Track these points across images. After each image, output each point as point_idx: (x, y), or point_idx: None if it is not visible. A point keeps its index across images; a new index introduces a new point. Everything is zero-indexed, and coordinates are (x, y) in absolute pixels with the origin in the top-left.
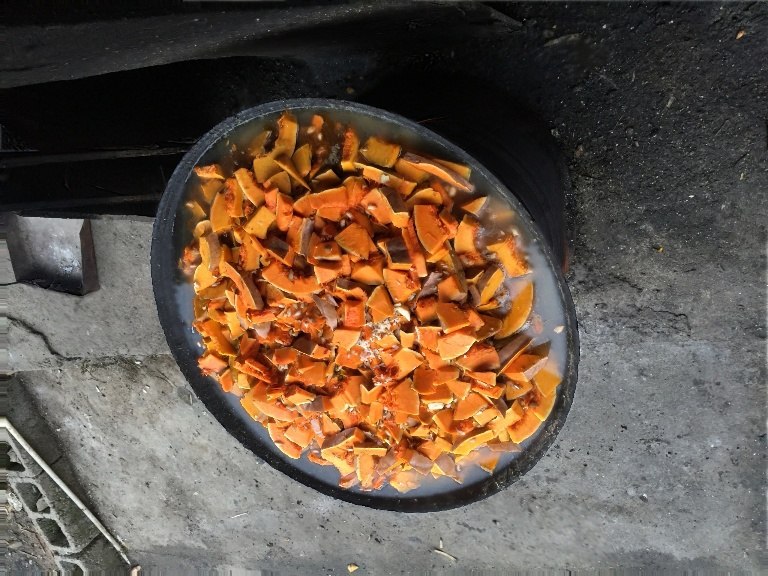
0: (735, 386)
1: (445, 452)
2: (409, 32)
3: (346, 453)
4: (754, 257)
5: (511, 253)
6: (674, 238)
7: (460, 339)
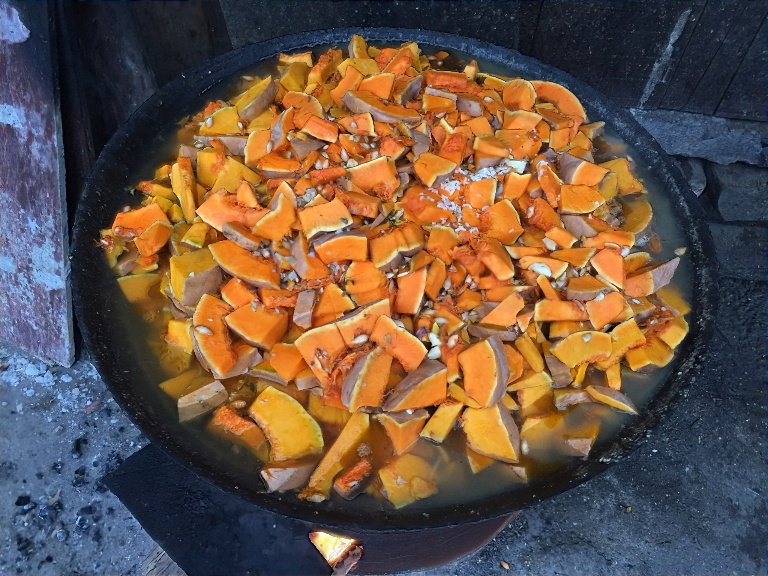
0: None
1: (507, 409)
2: None
3: (339, 359)
4: (730, 536)
5: (627, 170)
6: (642, 497)
7: (588, 193)
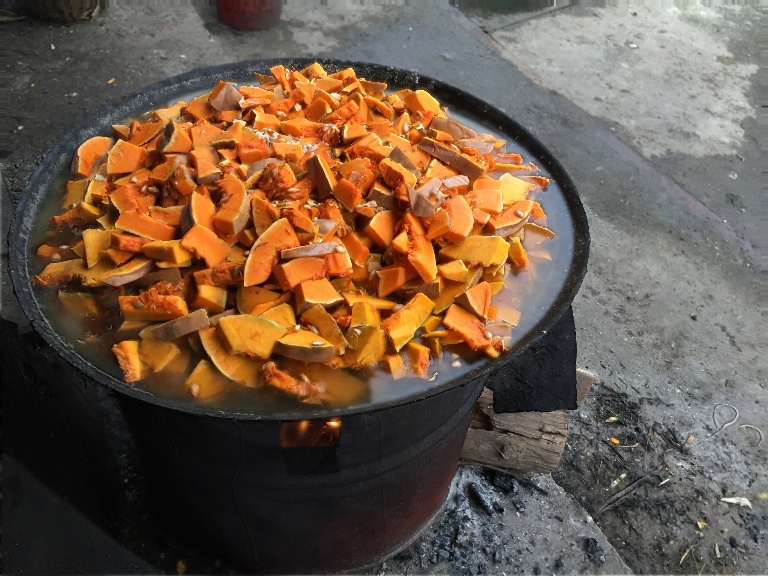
0: None
1: None
2: (62, 428)
3: None
4: None
5: None
6: None
7: None
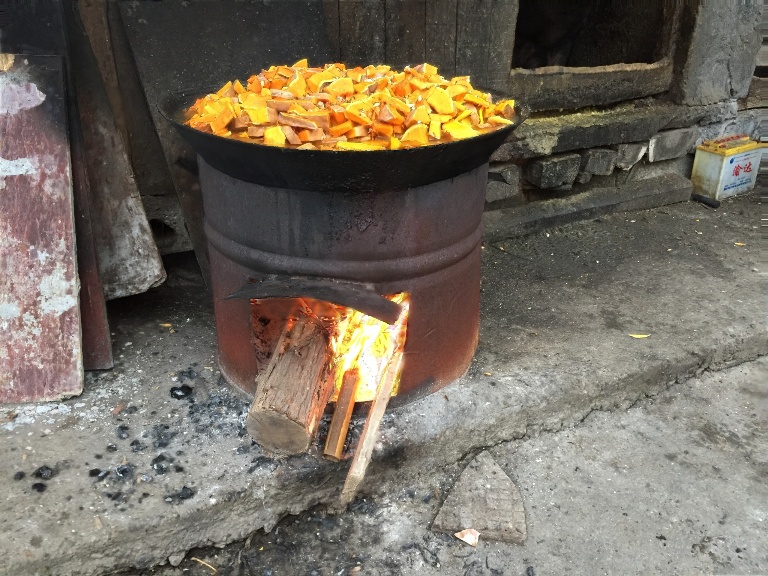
0: (701, 450)
1: None
2: None
3: None
4: None
5: None
6: None
7: None
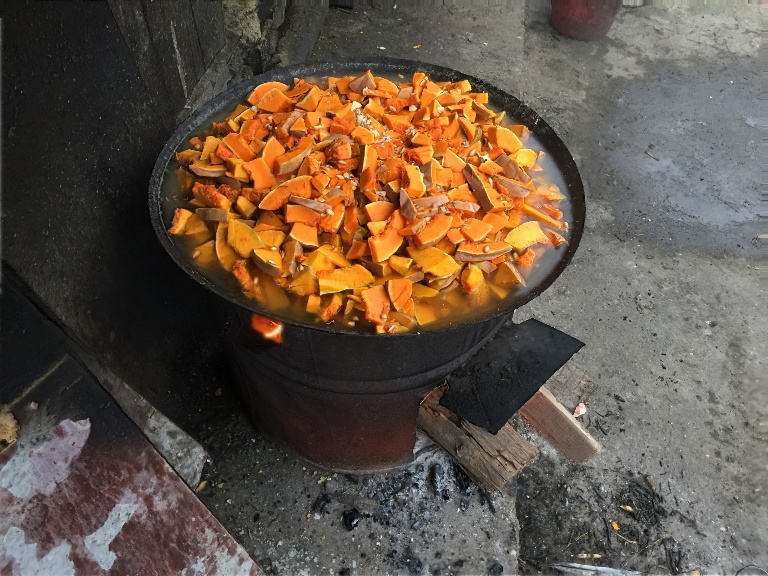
0: None
1: None
2: None
3: None
4: None
5: None
6: None
7: None
